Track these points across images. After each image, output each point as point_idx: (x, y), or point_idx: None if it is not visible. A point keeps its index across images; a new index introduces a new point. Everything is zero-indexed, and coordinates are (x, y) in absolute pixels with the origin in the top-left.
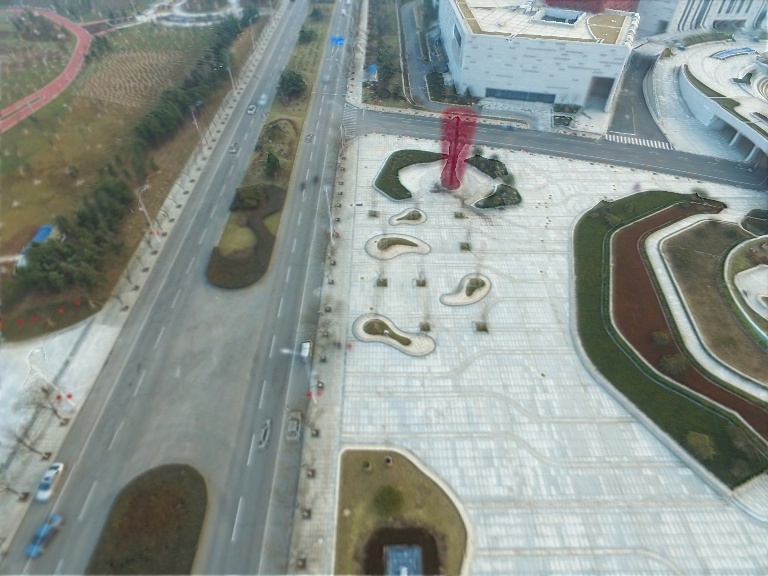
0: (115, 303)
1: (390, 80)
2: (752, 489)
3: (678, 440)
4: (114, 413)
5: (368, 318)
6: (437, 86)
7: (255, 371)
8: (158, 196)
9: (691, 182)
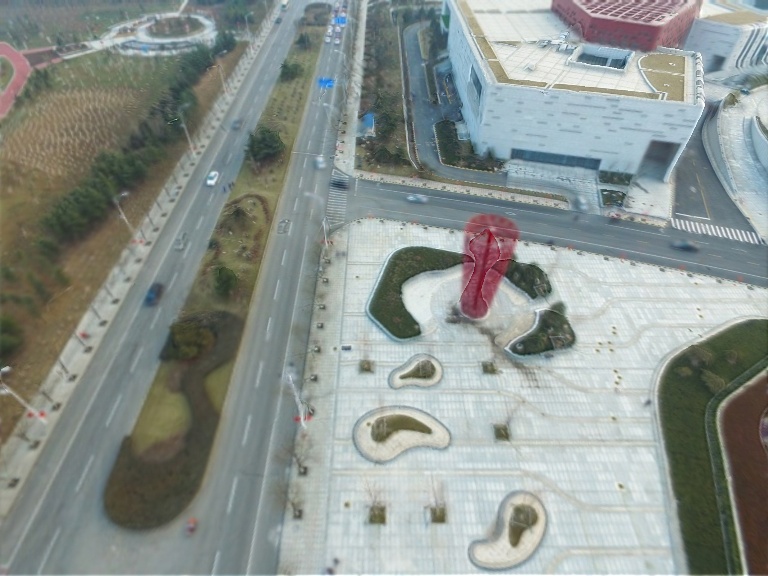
0: None
1: (391, 135)
2: None
3: None
4: None
5: None
6: (450, 144)
7: None
8: (61, 332)
9: None
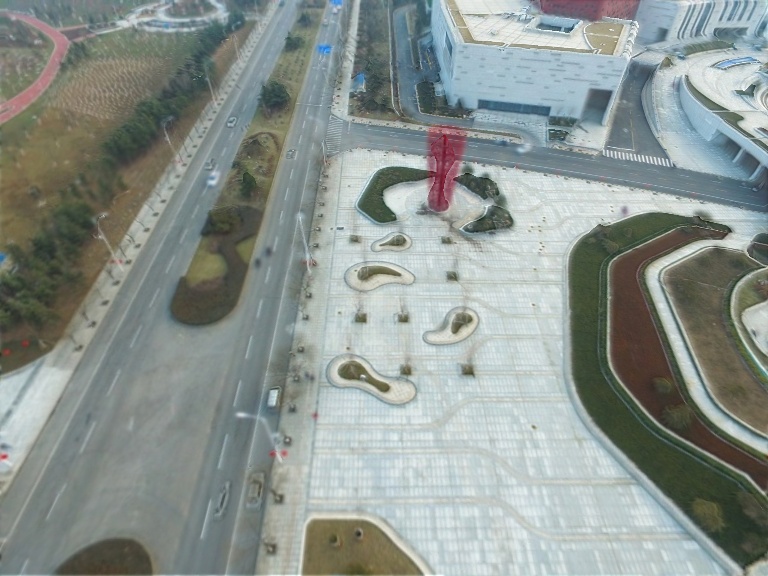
0: (68, 342)
1: (378, 90)
2: (766, 567)
3: (683, 508)
4: (56, 474)
5: (344, 360)
6: (427, 97)
7: (216, 423)
8: (125, 218)
9: (693, 203)
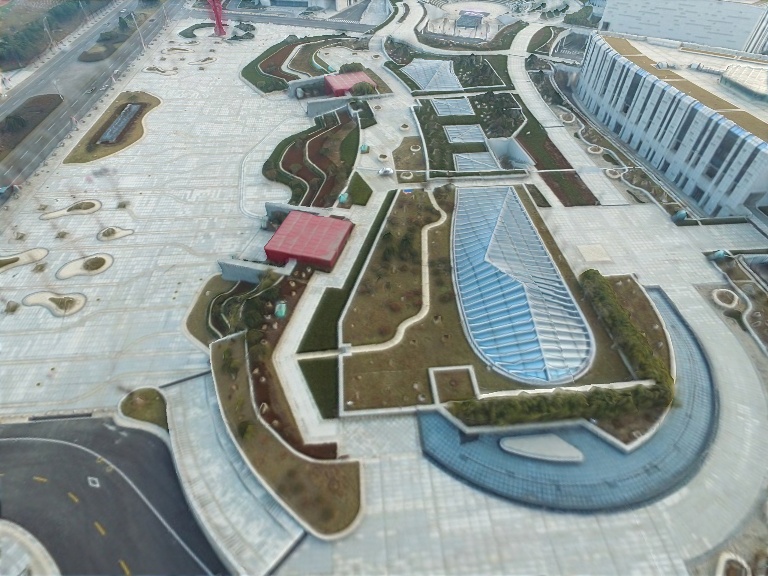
0: (32, 64)
1: None
2: (275, 94)
3: (256, 85)
4: (29, 88)
5: None
6: (242, 0)
7: (93, 79)
8: (59, 38)
9: (352, 33)
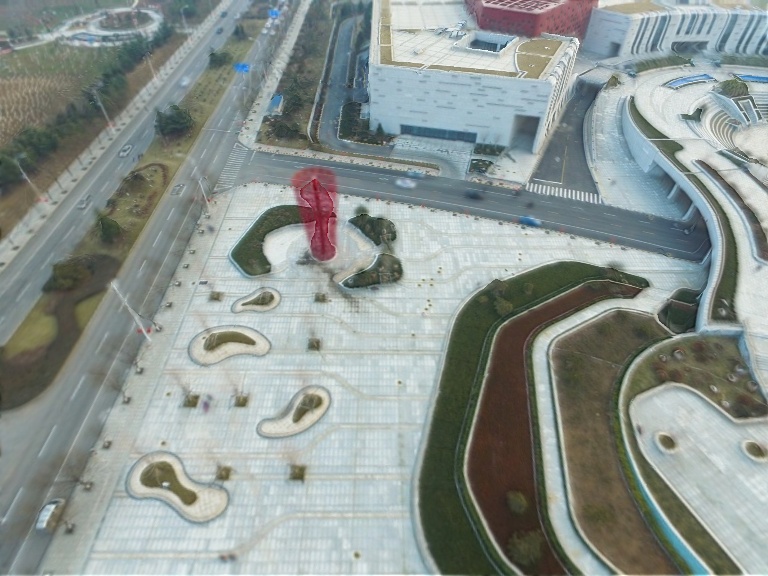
0: None
1: (295, 114)
2: None
3: None
4: None
5: (152, 460)
6: (347, 121)
7: None
8: None
9: (613, 249)
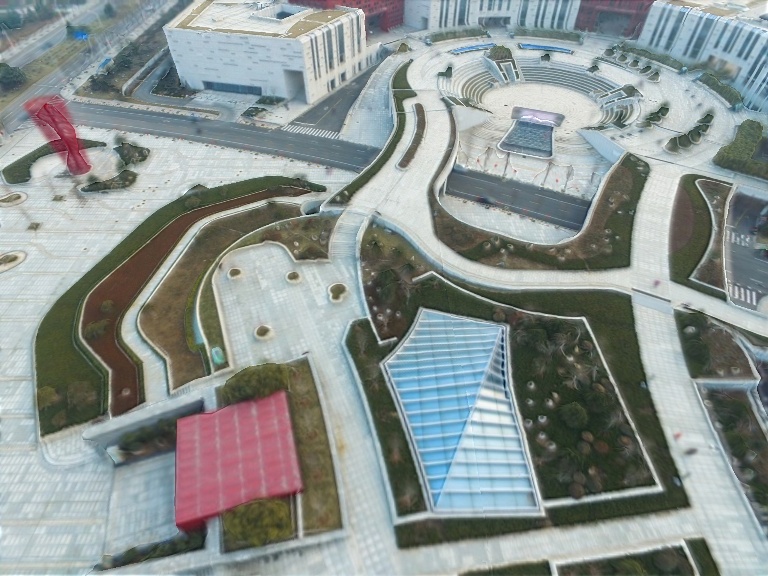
0: None
1: (119, 73)
2: (68, 436)
3: None
4: None
5: None
6: None
7: None
8: None
9: (318, 168)
